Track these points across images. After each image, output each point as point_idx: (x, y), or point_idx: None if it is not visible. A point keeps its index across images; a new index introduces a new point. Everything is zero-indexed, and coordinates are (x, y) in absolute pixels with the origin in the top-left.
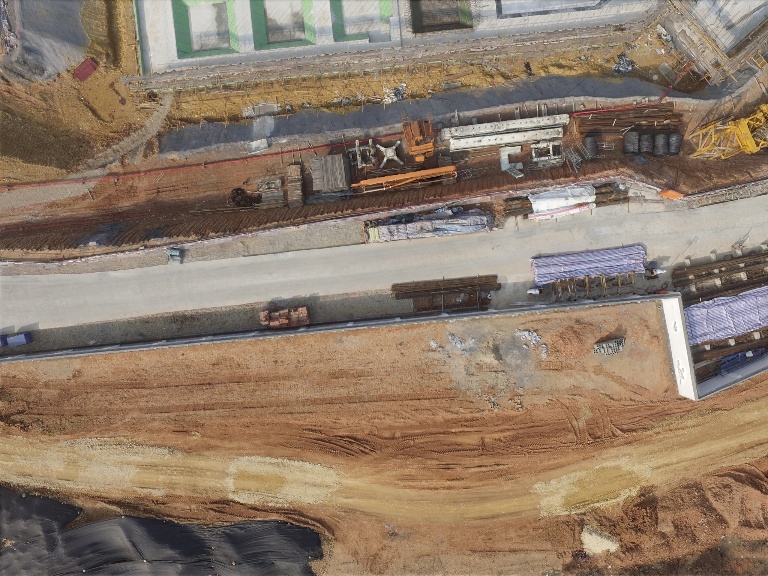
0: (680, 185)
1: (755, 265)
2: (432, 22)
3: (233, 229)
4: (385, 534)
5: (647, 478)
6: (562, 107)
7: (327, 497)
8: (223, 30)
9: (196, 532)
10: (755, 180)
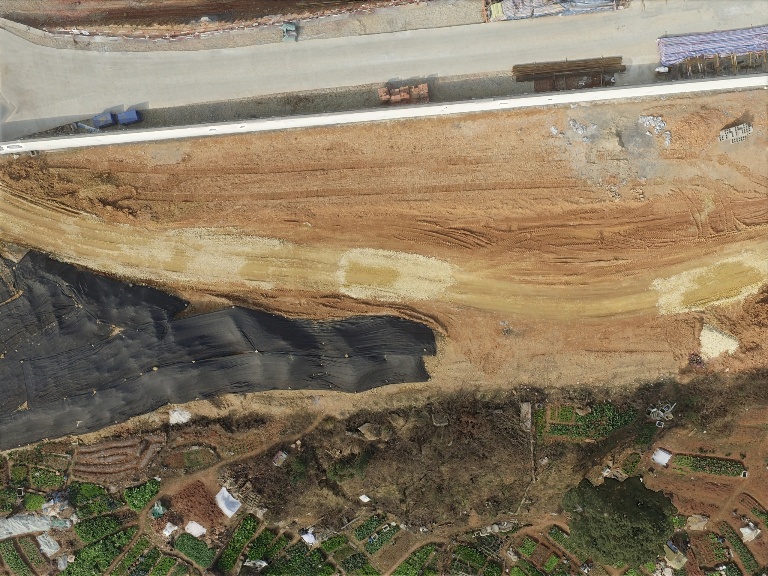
0: None
1: None
2: None
3: (348, 9)
4: (499, 331)
5: None
6: None
7: (440, 292)
8: None
9: (306, 327)
10: None
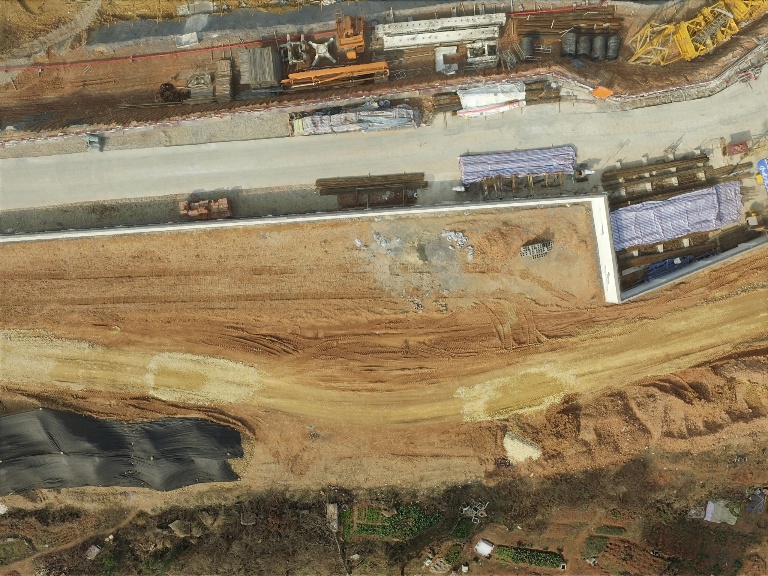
0: (614, 86)
1: (687, 170)
2: None
3: (156, 119)
4: (306, 435)
5: (571, 386)
6: (500, 8)
7: (249, 396)
8: None
9: (116, 428)
10: (691, 83)
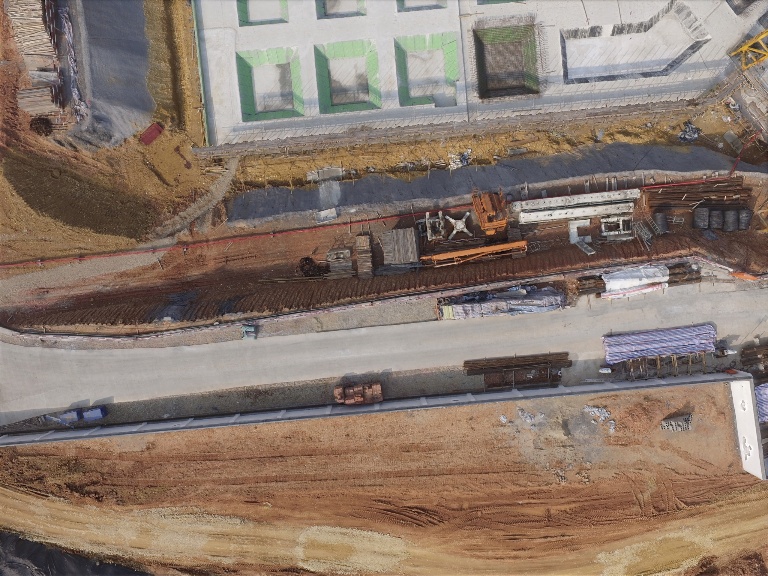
0: (751, 264)
1: None
2: (497, 85)
3: (306, 304)
4: None
5: (709, 549)
6: (632, 180)
7: (395, 565)
8: (287, 91)
9: None
10: None
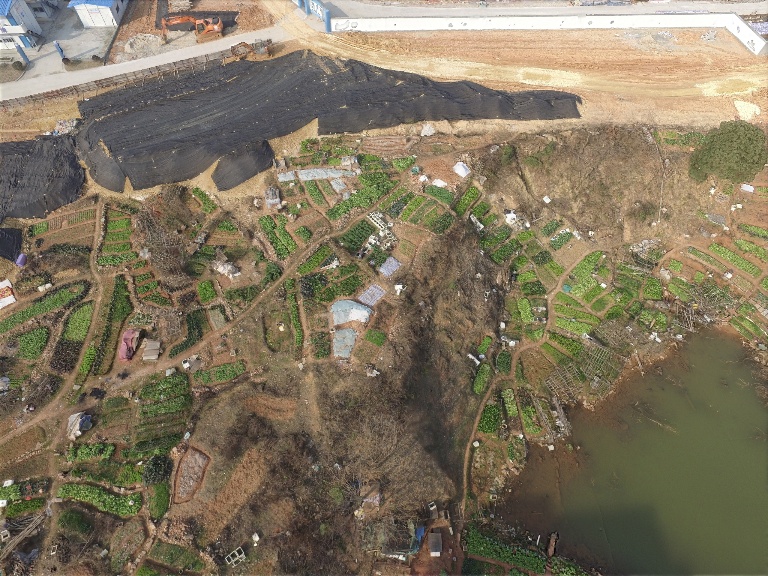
0: None
1: (765, 18)
2: None
3: None
4: (616, 99)
5: (759, 84)
6: None
7: (577, 84)
8: None
9: (503, 93)
10: None
